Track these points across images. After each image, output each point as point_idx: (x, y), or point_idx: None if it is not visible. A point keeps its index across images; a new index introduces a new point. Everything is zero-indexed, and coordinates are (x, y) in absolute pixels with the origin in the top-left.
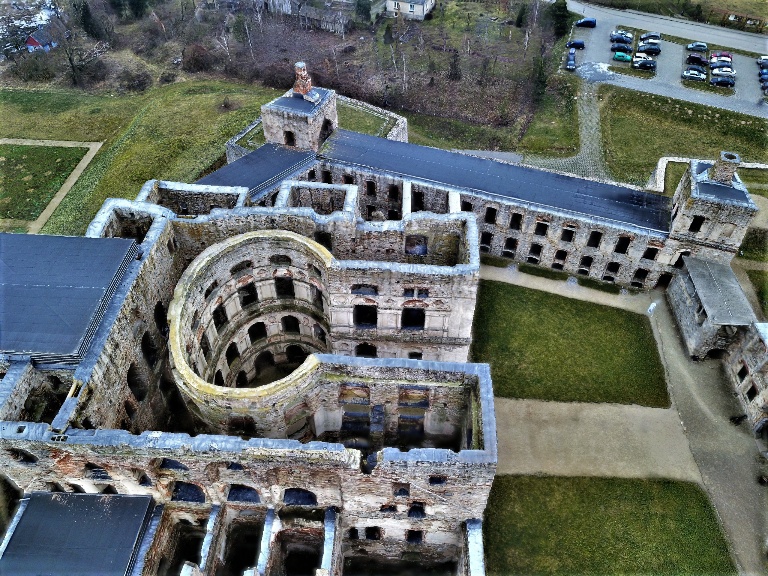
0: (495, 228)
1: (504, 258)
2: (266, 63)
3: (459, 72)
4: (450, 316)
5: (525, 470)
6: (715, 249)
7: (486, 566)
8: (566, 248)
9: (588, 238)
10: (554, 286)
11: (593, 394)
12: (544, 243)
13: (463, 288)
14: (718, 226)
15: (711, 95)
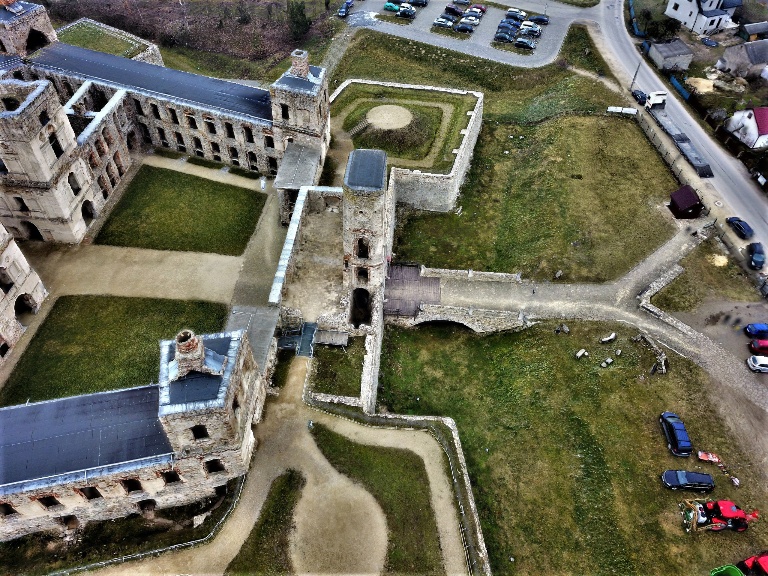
0: (162, 123)
1: (180, 152)
2: (90, 8)
3: (246, 17)
4: (20, 159)
5: (96, 292)
6: (305, 134)
7: (25, 350)
8: (214, 140)
9: (225, 129)
10: (207, 172)
11: (185, 245)
12: (199, 136)
13: (13, 131)
14: (298, 113)
15: (448, 39)
